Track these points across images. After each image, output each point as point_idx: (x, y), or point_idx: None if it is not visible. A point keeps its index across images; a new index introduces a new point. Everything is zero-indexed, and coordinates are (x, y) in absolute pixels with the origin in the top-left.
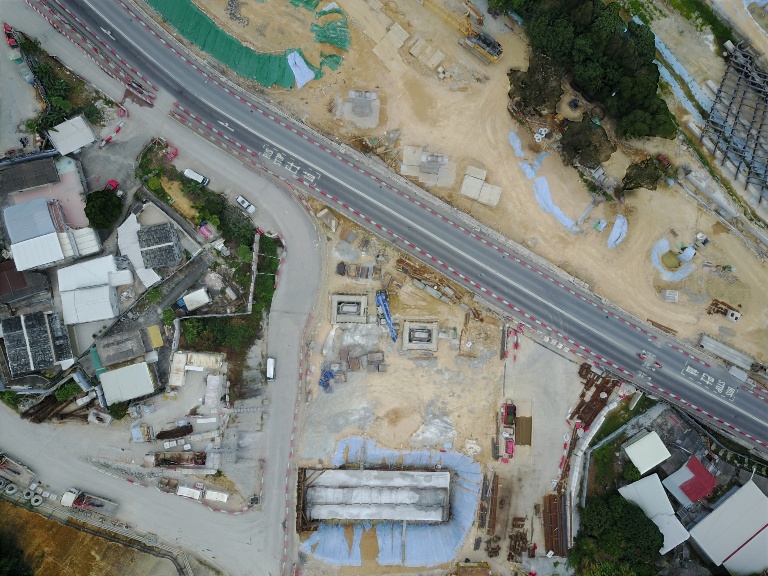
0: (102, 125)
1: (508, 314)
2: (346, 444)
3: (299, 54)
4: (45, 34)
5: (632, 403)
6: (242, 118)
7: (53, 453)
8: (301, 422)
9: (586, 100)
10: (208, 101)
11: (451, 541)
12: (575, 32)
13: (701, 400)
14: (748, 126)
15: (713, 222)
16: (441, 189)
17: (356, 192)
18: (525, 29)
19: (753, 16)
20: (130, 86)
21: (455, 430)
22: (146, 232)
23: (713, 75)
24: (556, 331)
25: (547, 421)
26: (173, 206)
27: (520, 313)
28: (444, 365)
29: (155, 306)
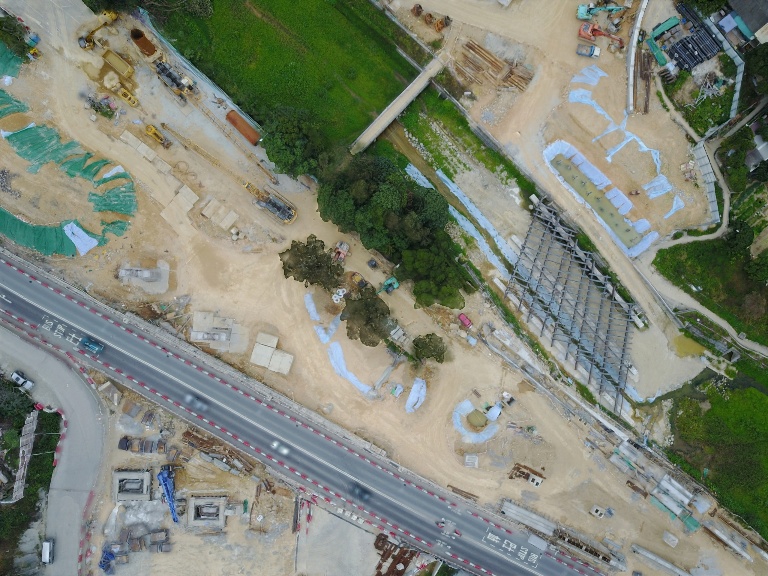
0: None
1: (301, 485)
2: None
3: (76, 225)
4: None
5: (434, 570)
6: (20, 289)
7: None
8: None
9: (386, 259)
10: None
11: None
12: (357, 203)
13: (503, 568)
14: (553, 282)
15: (518, 380)
16: (233, 355)
17: (141, 362)
18: None
19: (559, 168)
20: None
21: None
22: None
23: (519, 229)
24: (351, 502)
25: None
26: None
27: (313, 484)
28: (233, 540)
29: None
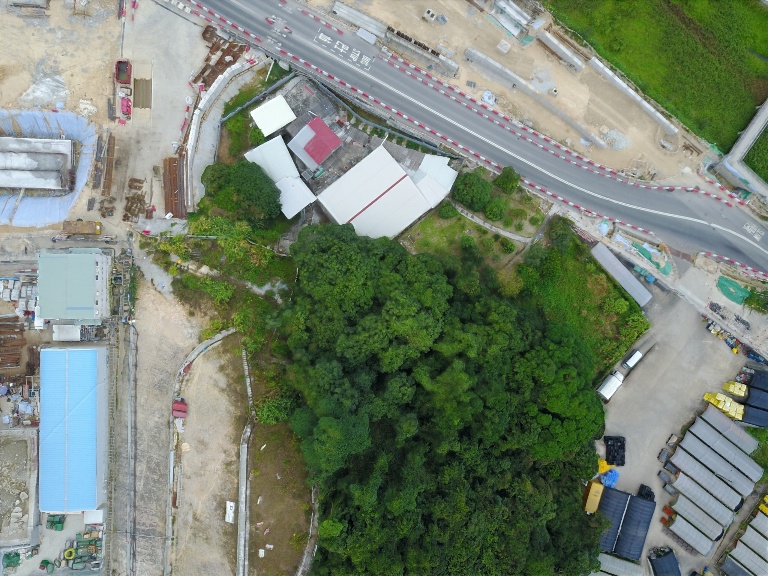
0: None
1: None
2: None
3: None
4: None
5: None
6: None
7: None
8: None
9: None
10: None
11: (67, 205)
12: None
13: (335, 68)
14: None
15: None
16: None
17: None
18: None
19: None
20: None
21: (68, 90)
22: None
23: None
24: None
25: (169, 84)
26: None
27: None
28: (57, 24)
29: None
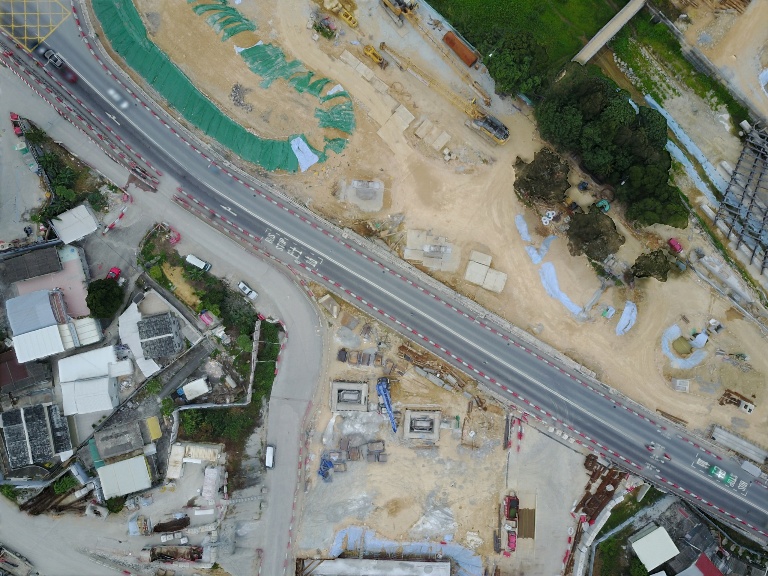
0: (105, 211)
1: (512, 403)
2: (345, 534)
3: (302, 139)
4: (50, 122)
5: (640, 495)
6: (245, 202)
7: (51, 544)
8: (300, 511)
9: (595, 182)
10: (211, 185)
11: None
12: (583, 119)
13: (712, 494)
14: (764, 209)
15: (727, 308)
16: (445, 274)
17: (358, 277)
18: (533, 111)
19: None
20: (134, 171)
21: (456, 522)
22: (146, 323)
23: (728, 155)
24: (561, 421)
25: (551, 514)
26: (174, 293)
27: (524, 402)
28: (446, 454)
29: (155, 395)
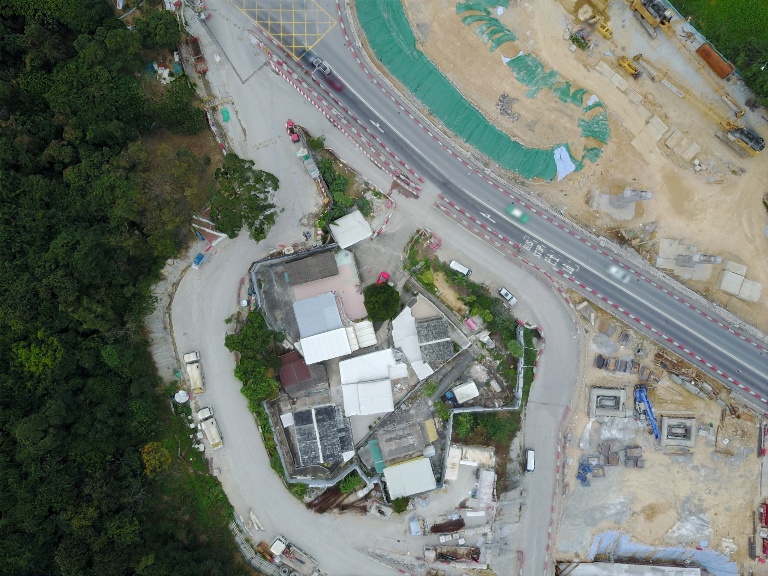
0: (372, 216)
1: (765, 412)
2: (600, 537)
3: (566, 149)
4: (324, 129)
5: None
6: (503, 210)
7: (332, 542)
8: (558, 514)
9: None
10: (471, 193)
11: None
12: None
13: None
14: None
15: None
16: (697, 283)
17: (614, 285)
18: None
19: None
20: (398, 178)
21: (712, 528)
22: (426, 327)
23: None
24: None
25: None
26: (440, 298)
27: None
28: (700, 461)
29: (426, 398)
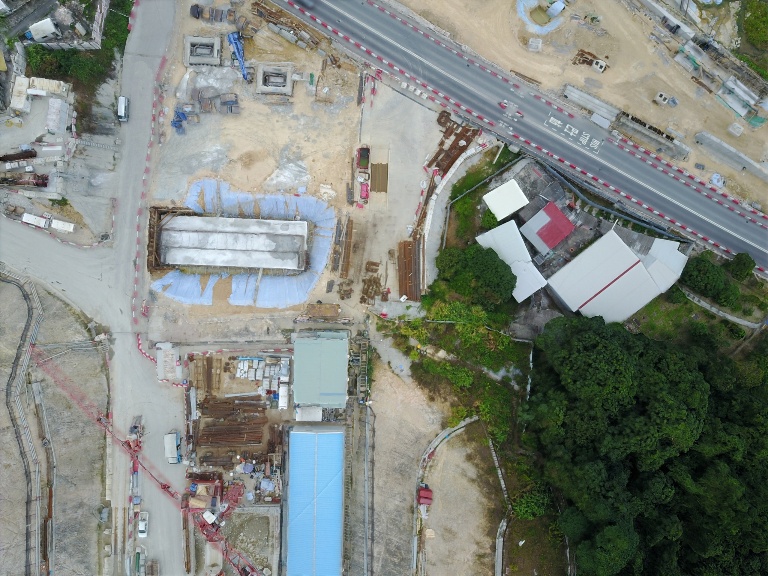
0: None
1: (366, 60)
2: (200, 188)
3: None
4: None
5: (495, 157)
6: None
7: None
8: (154, 163)
9: None
10: None
11: (305, 286)
12: None
13: (564, 152)
14: None
15: None
16: None
17: None
18: None
19: None
20: None
21: (309, 174)
22: None
23: None
24: (415, 78)
25: (404, 168)
26: None
27: (378, 60)
28: (300, 111)
29: (2, 36)
